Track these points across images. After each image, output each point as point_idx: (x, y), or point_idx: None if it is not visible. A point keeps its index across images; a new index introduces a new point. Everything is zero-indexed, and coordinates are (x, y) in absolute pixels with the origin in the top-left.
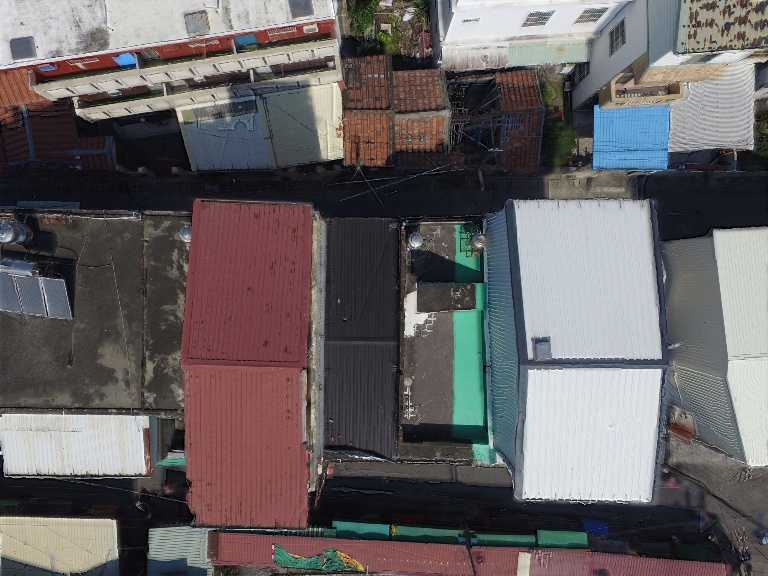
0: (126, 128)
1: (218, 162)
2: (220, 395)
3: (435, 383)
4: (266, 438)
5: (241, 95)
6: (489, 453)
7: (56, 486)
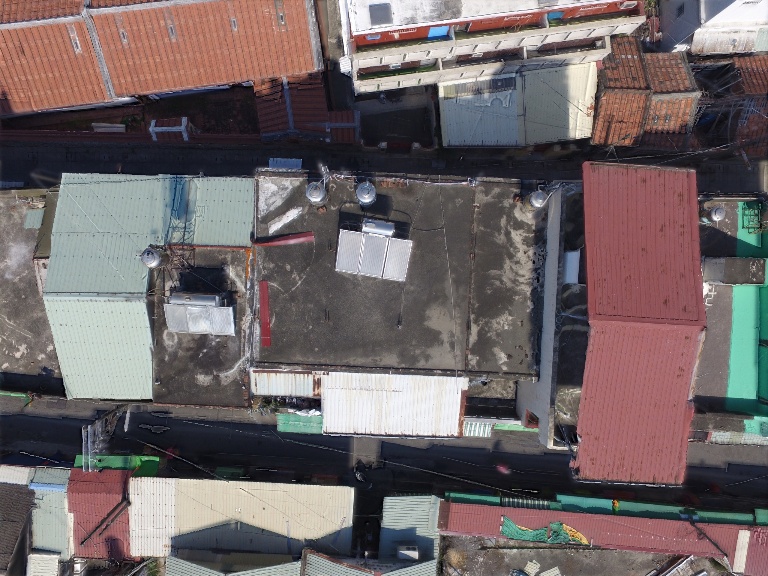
0: (360, 104)
1: (469, 138)
2: (621, 351)
3: (712, 356)
4: (656, 395)
5: (504, 72)
6: (760, 426)
7: (274, 455)
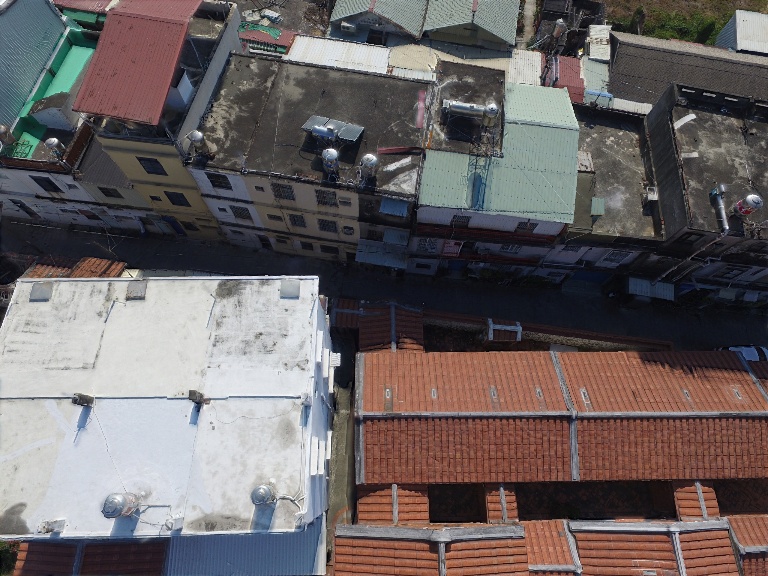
0: None
1: None
2: (173, 8)
3: None
4: None
5: None
6: None
7: None
